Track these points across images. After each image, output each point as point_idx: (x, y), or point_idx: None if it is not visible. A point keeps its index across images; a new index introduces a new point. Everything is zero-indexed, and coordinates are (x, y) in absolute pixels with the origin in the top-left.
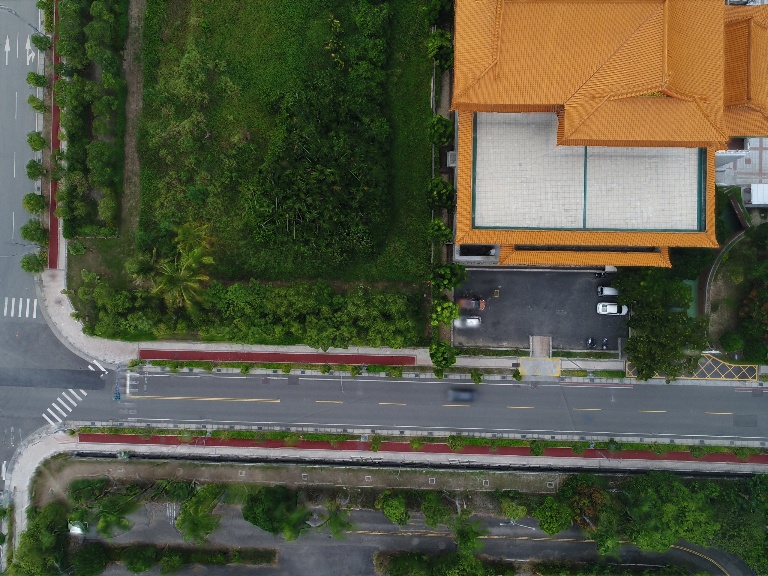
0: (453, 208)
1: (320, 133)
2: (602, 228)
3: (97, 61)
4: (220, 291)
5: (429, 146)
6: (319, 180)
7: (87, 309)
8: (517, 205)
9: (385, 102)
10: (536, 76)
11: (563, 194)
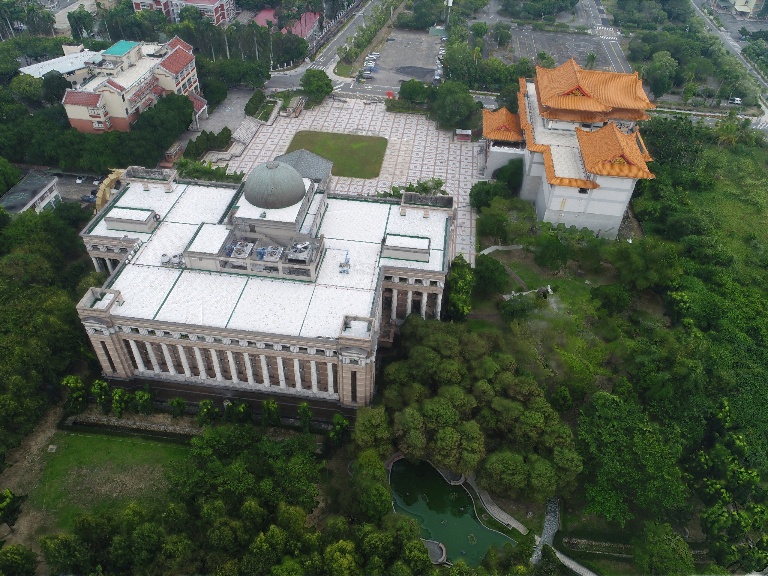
0: None
1: None
2: None
3: None
4: None
5: None
6: None
7: (767, 144)
8: None
9: None
10: None
11: None
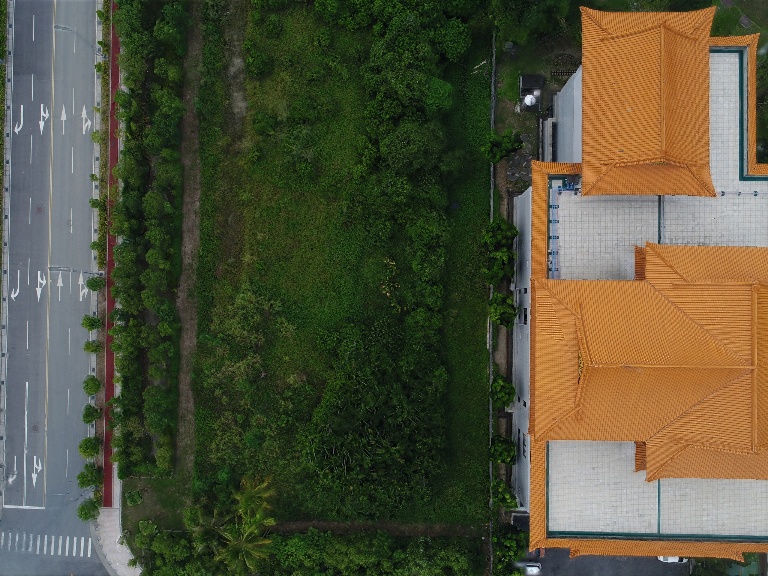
0: (514, 462)
1: (377, 377)
2: (677, 533)
3: (153, 310)
4: (279, 543)
5: (486, 387)
6: (384, 457)
7: (142, 550)
8: (591, 510)
9: (442, 346)
10: (618, 418)
11: (637, 499)
